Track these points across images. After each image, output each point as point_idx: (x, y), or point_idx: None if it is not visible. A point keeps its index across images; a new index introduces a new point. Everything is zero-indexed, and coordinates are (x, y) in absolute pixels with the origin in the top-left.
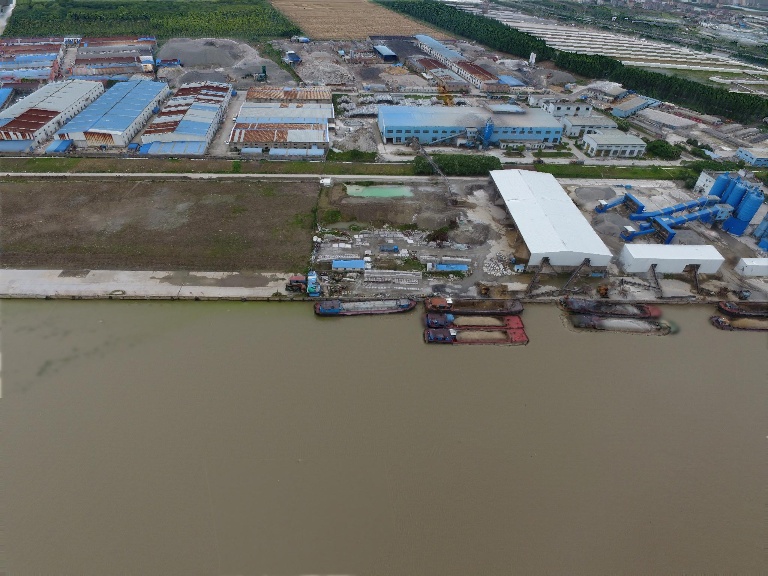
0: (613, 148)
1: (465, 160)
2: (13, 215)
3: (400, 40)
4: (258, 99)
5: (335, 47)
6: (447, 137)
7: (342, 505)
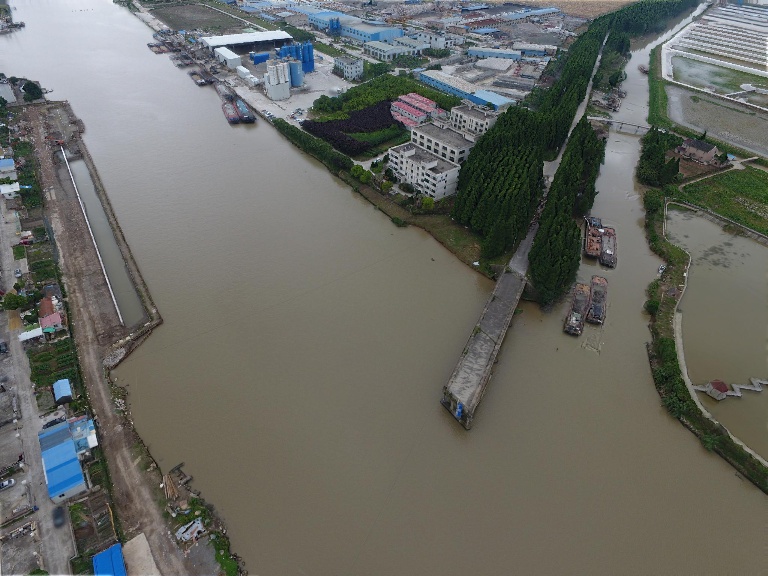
0: (371, 49)
1: (295, 31)
2: (181, 10)
3: (516, 7)
4: (324, 7)
5: (459, 3)
6: (324, 27)
7: (73, 38)
